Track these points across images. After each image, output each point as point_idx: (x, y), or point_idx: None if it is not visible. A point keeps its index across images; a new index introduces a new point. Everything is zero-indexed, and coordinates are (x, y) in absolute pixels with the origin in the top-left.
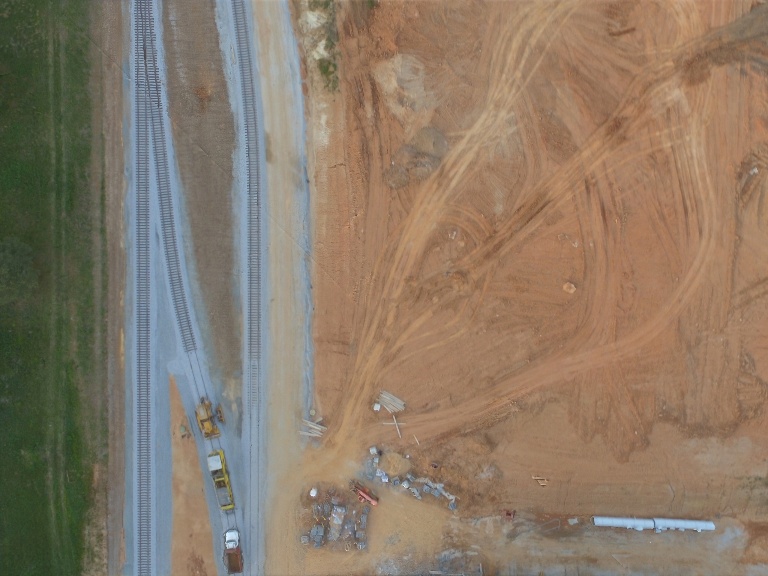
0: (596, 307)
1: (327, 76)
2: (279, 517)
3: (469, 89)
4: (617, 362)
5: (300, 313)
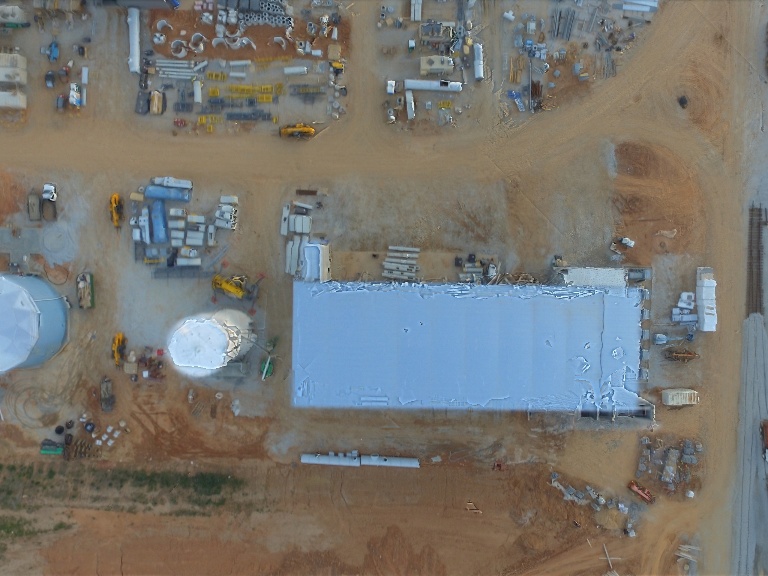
0: None
1: None
2: (723, 469)
3: None
4: None
5: None
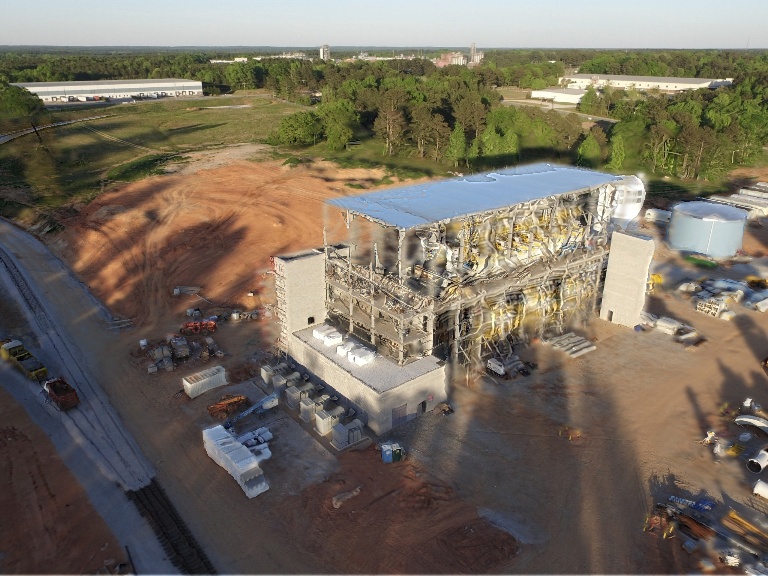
0: (302, 227)
1: (56, 230)
2: (111, 370)
3: (156, 203)
4: (338, 236)
5: (77, 290)
